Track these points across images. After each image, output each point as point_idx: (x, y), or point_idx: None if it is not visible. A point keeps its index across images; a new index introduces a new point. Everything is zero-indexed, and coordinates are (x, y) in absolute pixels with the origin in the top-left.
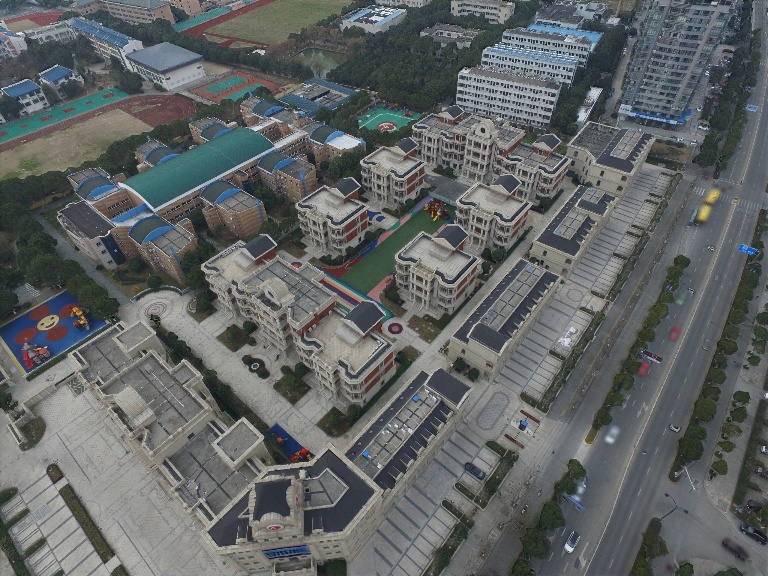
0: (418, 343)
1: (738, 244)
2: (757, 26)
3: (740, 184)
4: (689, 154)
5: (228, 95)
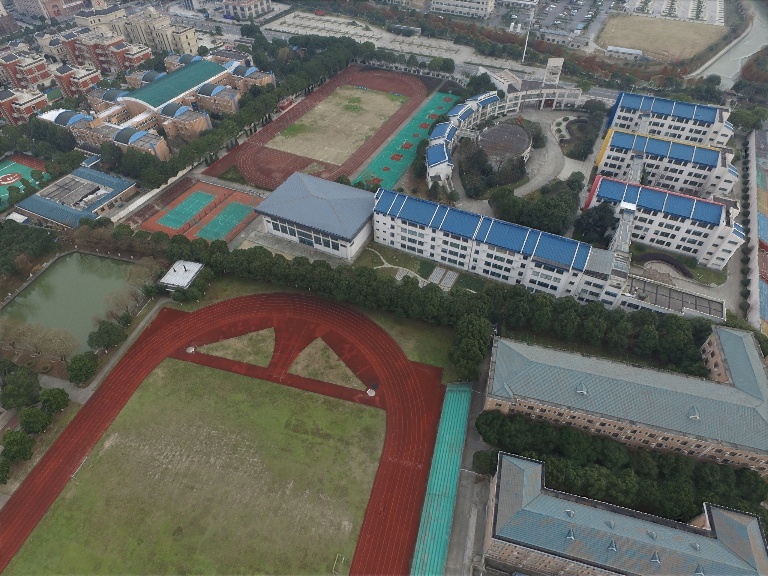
0: None
1: None
2: None
3: None
4: None
5: (212, 200)
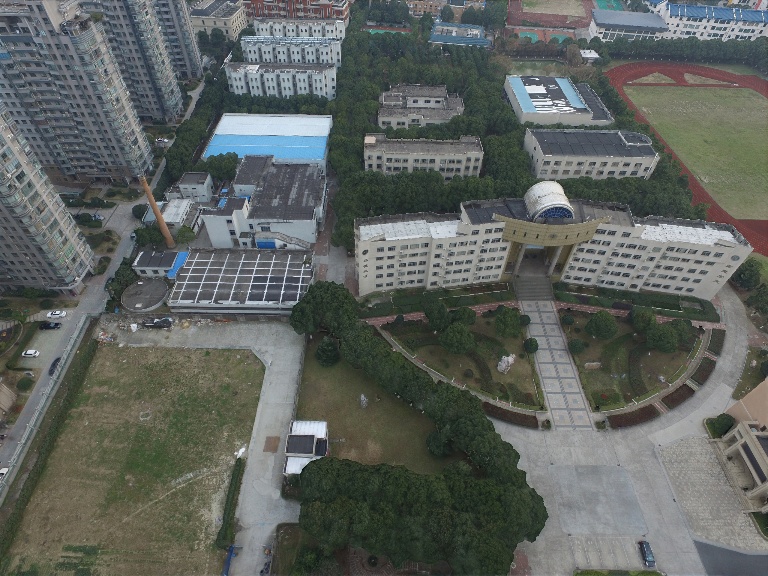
0: None
1: None
2: None
3: None
4: None
5: (537, 34)
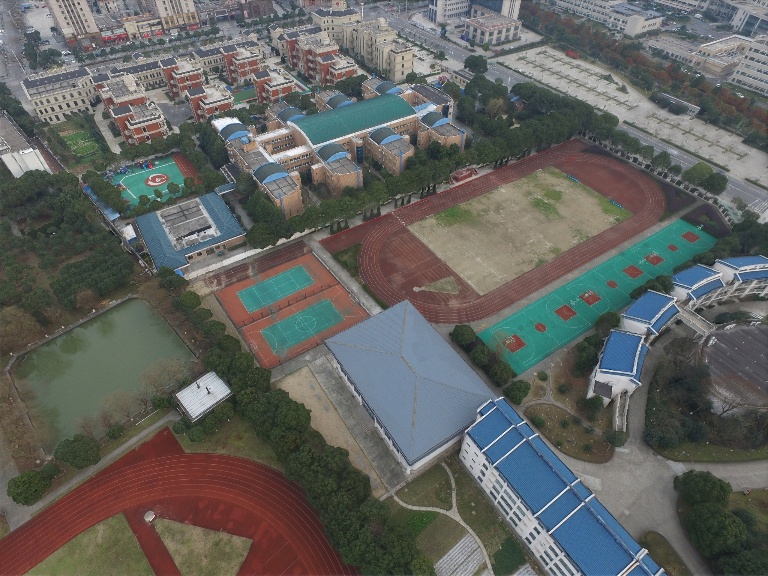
0: (272, 65)
1: None
2: None
3: None
4: None
5: (307, 286)
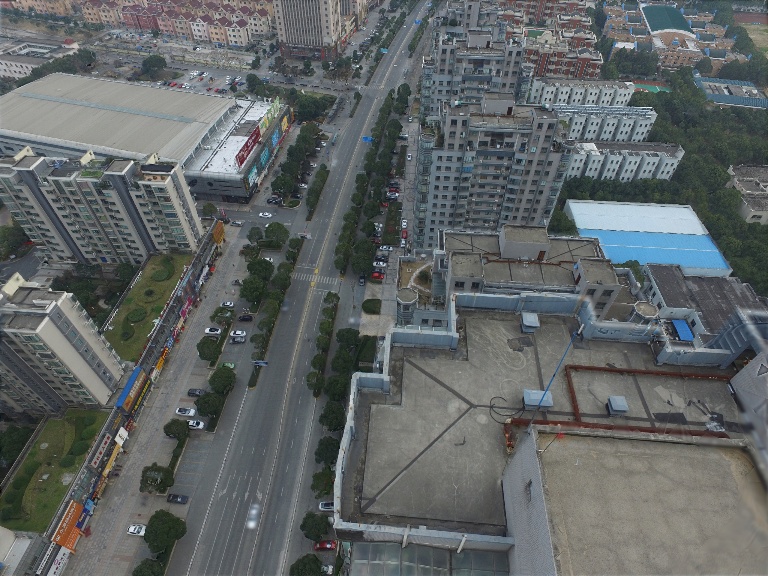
0: None
1: (382, 69)
2: (285, 503)
3: (378, 97)
4: (413, 110)
5: None
